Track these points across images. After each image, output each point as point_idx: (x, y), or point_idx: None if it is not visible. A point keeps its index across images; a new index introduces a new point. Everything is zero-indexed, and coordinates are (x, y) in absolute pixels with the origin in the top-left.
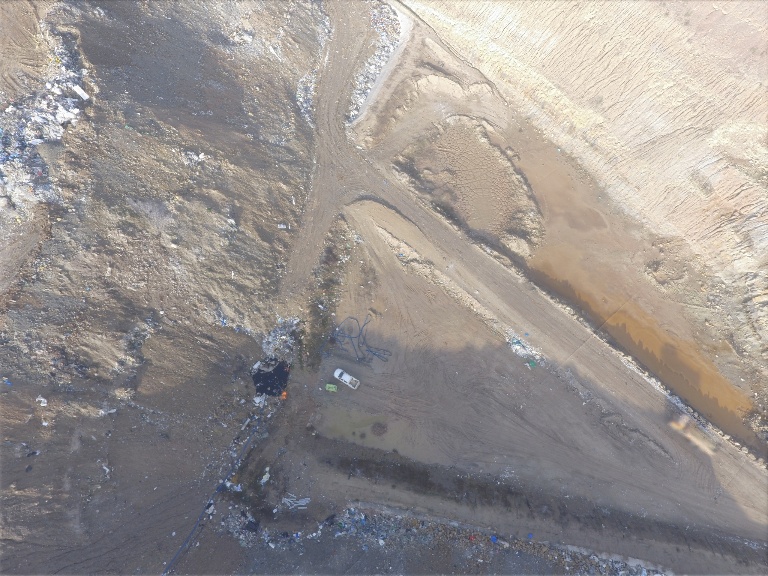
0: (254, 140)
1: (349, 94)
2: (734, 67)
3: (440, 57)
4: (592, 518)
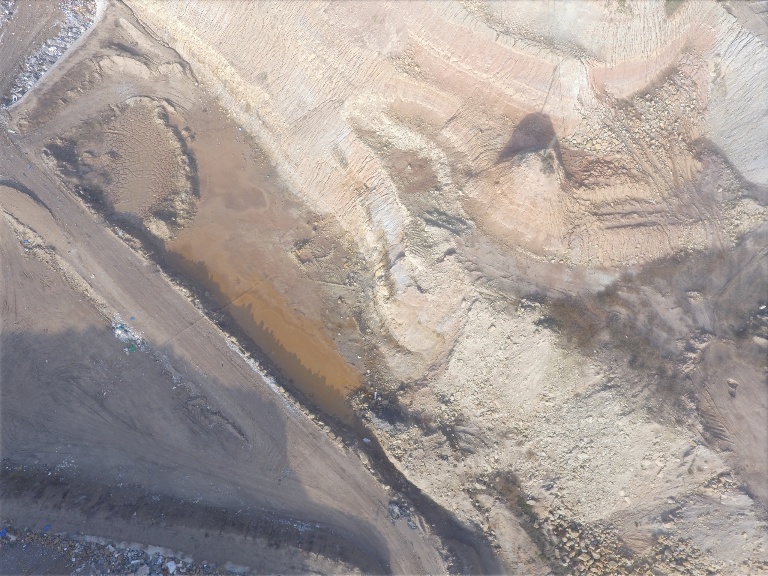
0: None
1: (13, 77)
2: (359, 36)
3: (134, 37)
4: (130, 506)
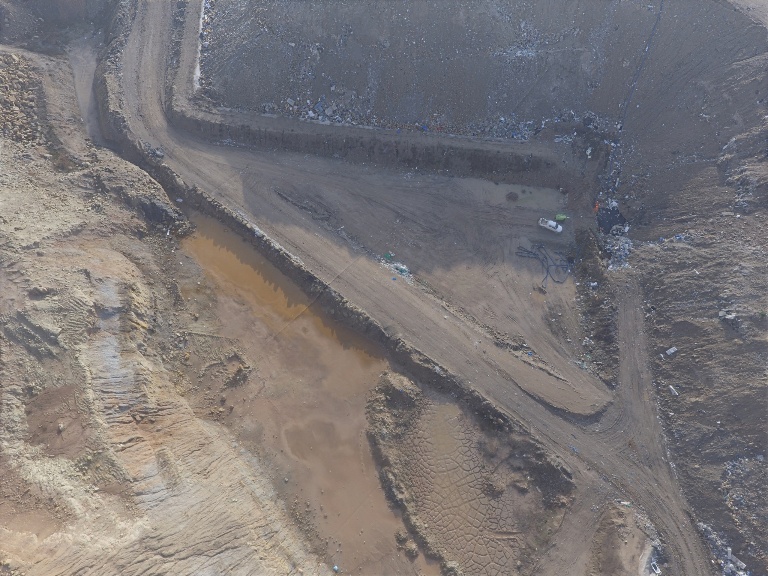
0: (767, 447)
1: None
2: None
3: None
4: (351, 147)
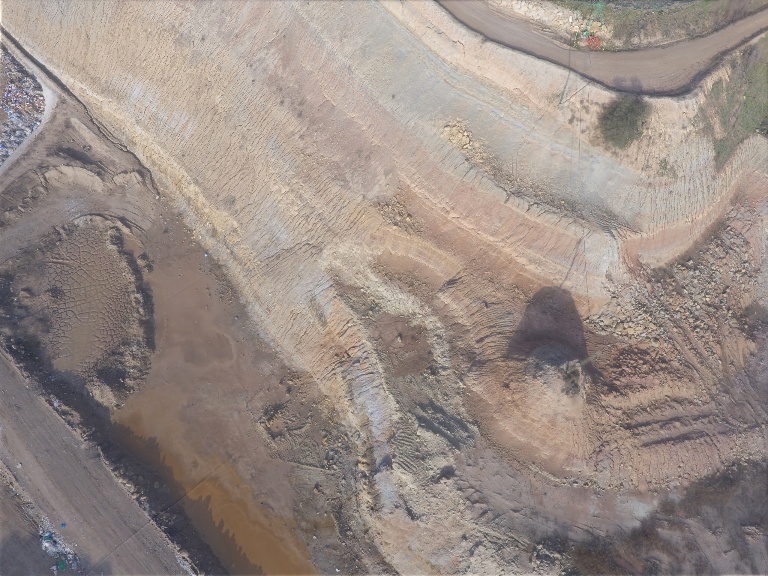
0: None
1: None
2: (341, 173)
3: (87, 140)
4: None
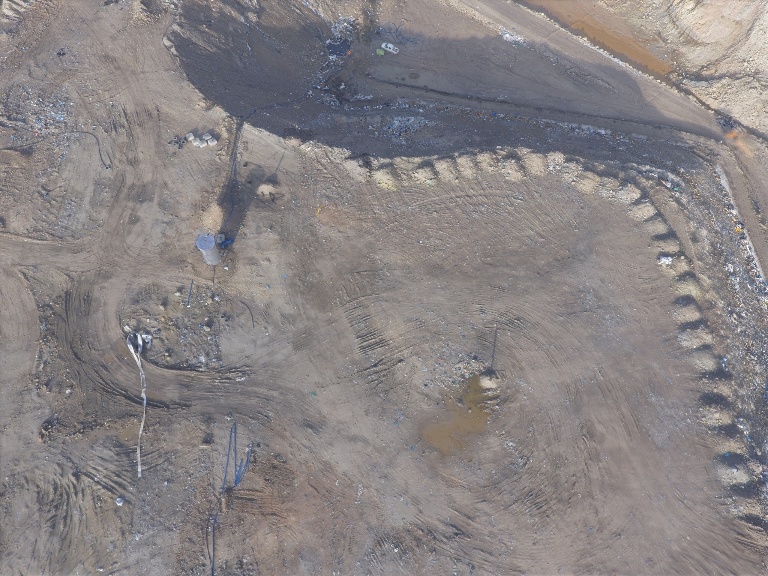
0: None
1: None
2: None
3: None
4: None
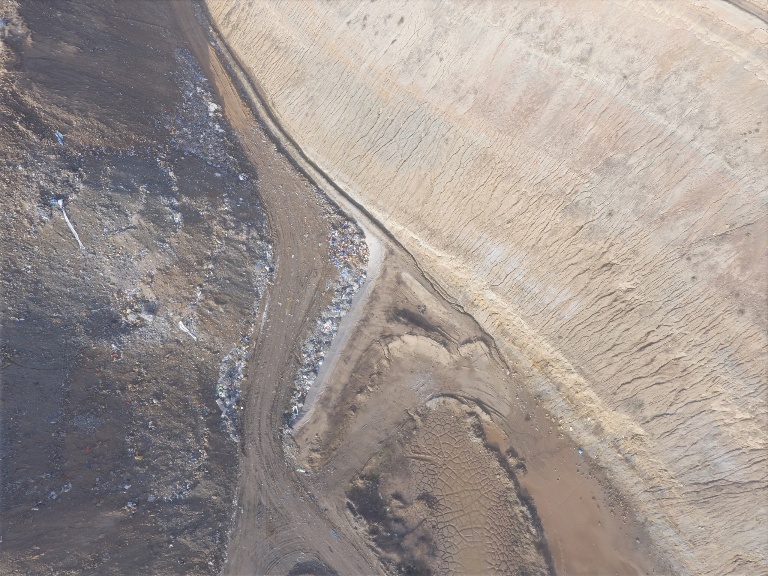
0: (138, 509)
1: (292, 377)
2: None
3: (420, 299)
4: None
